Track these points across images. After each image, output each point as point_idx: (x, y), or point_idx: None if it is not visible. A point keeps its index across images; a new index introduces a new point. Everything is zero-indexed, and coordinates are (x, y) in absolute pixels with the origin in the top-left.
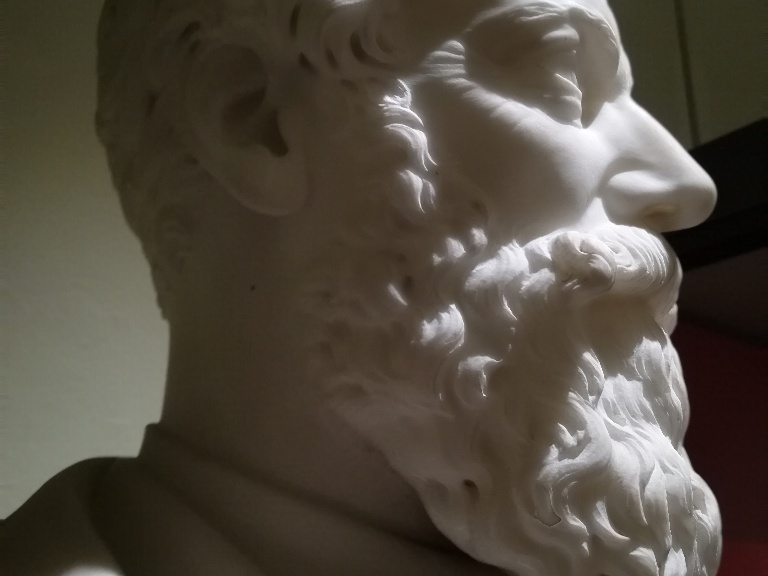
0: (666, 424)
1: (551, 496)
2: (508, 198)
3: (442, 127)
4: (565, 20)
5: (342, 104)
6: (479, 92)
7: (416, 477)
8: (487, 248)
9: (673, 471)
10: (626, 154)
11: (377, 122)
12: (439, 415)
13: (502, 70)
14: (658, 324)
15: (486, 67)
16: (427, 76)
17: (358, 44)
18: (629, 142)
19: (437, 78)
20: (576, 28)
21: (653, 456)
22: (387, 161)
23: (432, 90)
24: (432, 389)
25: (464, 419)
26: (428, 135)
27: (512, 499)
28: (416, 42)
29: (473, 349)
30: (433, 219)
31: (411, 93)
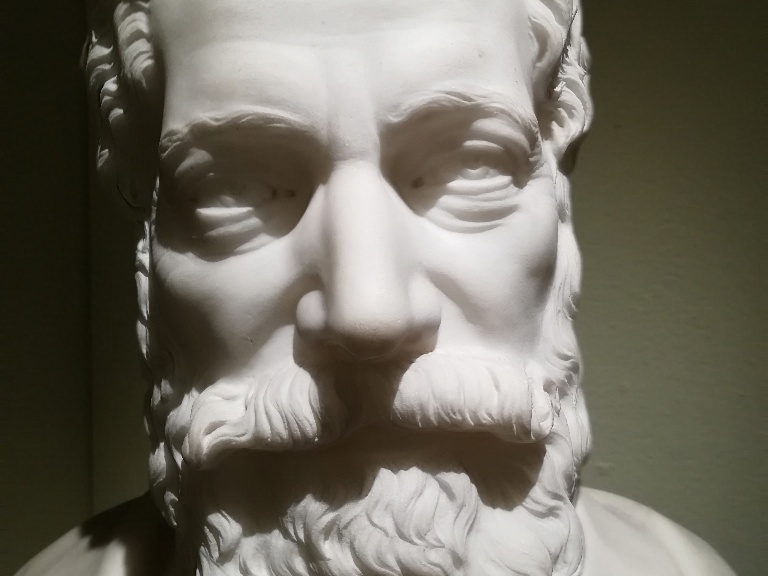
0: None
1: None
2: (190, 345)
3: (154, 274)
4: (189, 144)
5: None
6: (154, 243)
7: None
8: (177, 395)
9: None
10: (310, 269)
11: None
12: None
13: (173, 210)
14: (372, 468)
15: (163, 210)
16: None
17: None
18: (314, 251)
19: None
20: (205, 146)
21: None
22: None
23: None
24: None
25: None
26: (150, 282)
27: None
28: (147, 181)
29: (170, 484)
30: (151, 365)
31: (149, 236)
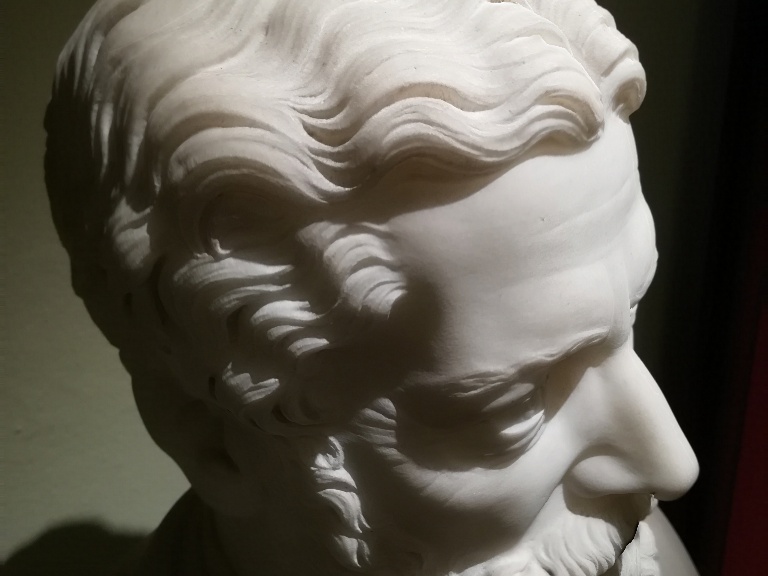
0: None
1: None
2: (446, 539)
3: (375, 490)
4: (513, 382)
5: (277, 458)
6: (409, 468)
7: None
8: None
9: None
10: (597, 441)
11: (310, 486)
12: None
13: (438, 432)
14: None
15: (419, 435)
16: (358, 437)
17: (281, 415)
18: (604, 428)
19: (368, 443)
20: (530, 379)
21: None
22: (324, 520)
23: (363, 453)
24: None
25: None
26: (362, 497)
27: None
28: (344, 400)
29: None
30: (369, 570)
31: (343, 451)
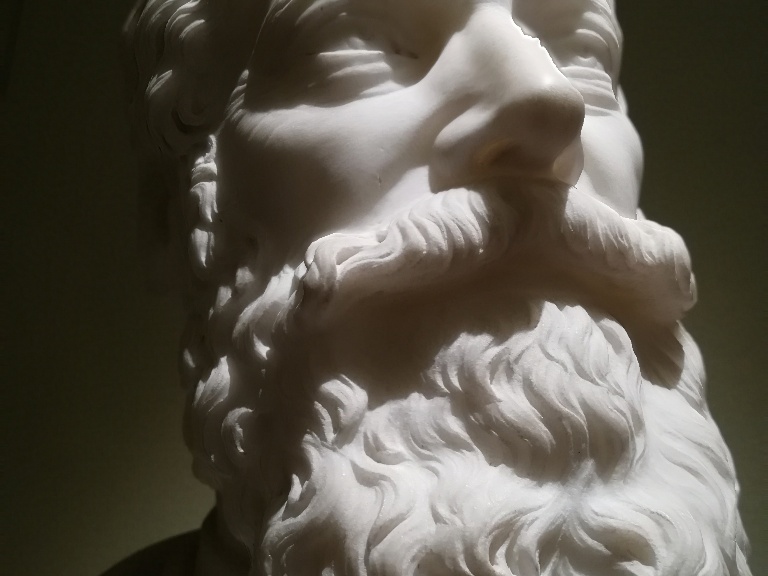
0: (499, 447)
1: (270, 564)
2: (284, 219)
3: (229, 169)
4: None
5: None
6: (245, 118)
7: (242, 541)
8: (257, 284)
9: (446, 519)
10: (455, 94)
11: None
12: (221, 477)
13: (274, 79)
14: (535, 301)
15: (259, 85)
16: (225, 120)
17: (179, 119)
18: (461, 76)
19: (228, 119)
20: None
21: (427, 500)
22: (192, 224)
23: (226, 134)
24: (204, 451)
25: (236, 478)
26: (219, 183)
27: (258, 567)
28: (221, 90)
29: (236, 401)
30: (213, 271)
31: (217, 144)
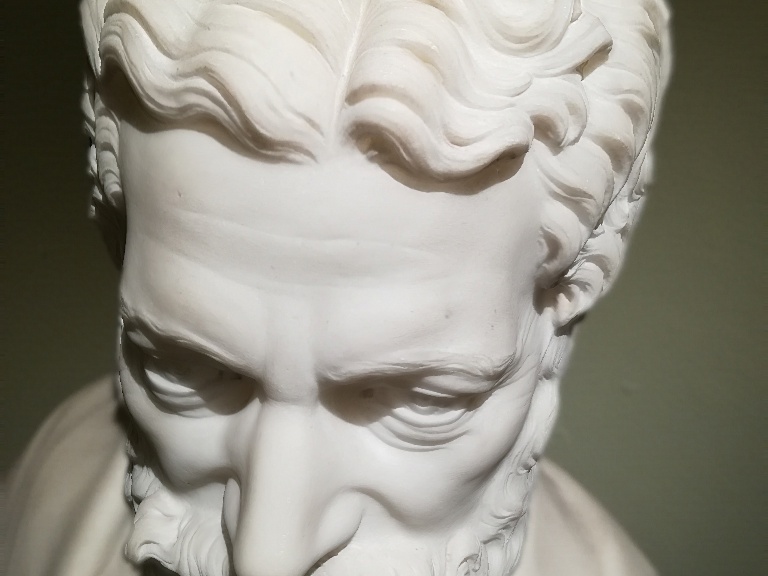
0: None
1: None
2: None
3: None
4: (136, 325)
5: None
6: None
7: None
8: (140, 459)
9: None
10: (236, 470)
11: None
12: None
13: None
14: None
15: None
16: None
17: None
18: (240, 462)
19: None
20: (149, 336)
21: None
22: None
23: None
24: None
25: None
26: None
27: None
28: None
29: None
30: None
31: None
